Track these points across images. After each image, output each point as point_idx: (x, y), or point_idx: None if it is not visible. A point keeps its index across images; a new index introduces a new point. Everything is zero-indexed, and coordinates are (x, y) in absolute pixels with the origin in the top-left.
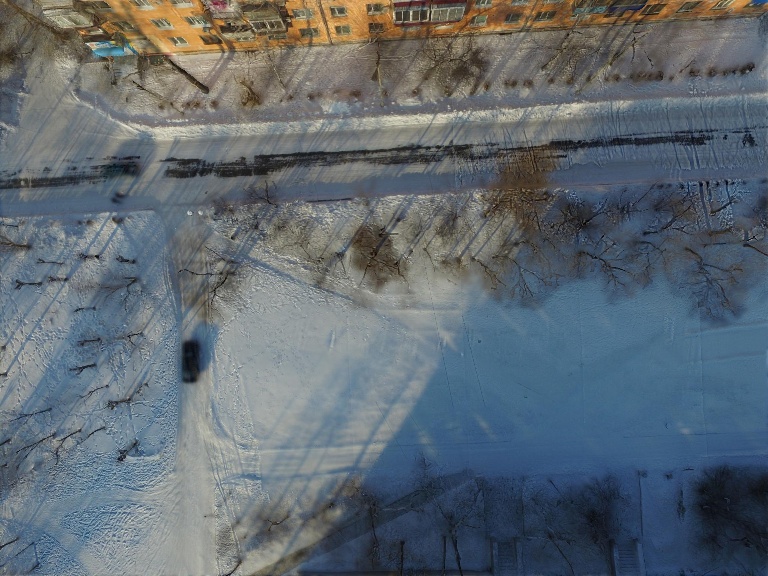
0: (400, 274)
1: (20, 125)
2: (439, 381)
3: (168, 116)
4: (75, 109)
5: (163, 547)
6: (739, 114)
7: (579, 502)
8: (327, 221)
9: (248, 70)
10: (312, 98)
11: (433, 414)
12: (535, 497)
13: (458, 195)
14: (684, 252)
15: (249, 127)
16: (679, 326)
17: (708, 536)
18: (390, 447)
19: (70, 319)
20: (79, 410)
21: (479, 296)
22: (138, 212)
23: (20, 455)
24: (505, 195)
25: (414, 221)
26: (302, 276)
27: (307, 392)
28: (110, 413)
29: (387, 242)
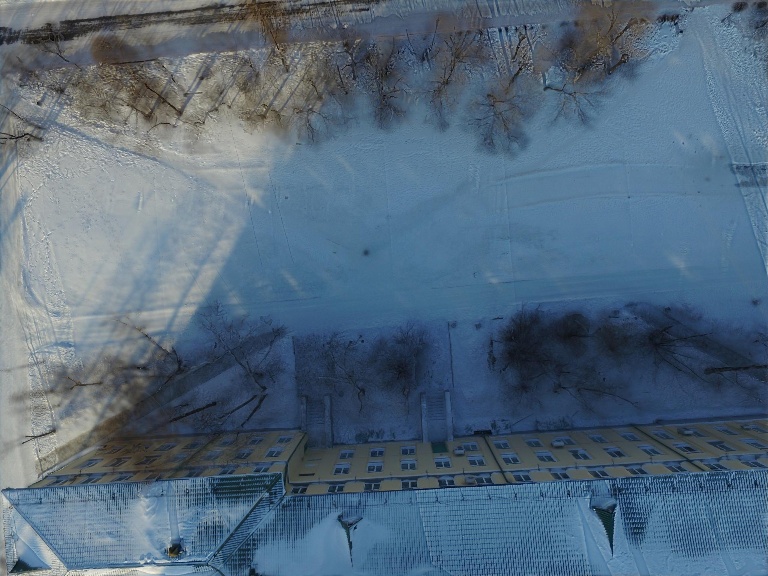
0: (195, 125)
1: None
2: (247, 239)
3: None
4: None
5: None
6: None
7: (384, 352)
8: (132, 83)
9: None
10: None
11: (242, 273)
12: None
13: (260, 51)
14: None
15: None
16: (484, 174)
17: (517, 383)
18: (201, 309)
19: None
20: None
21: (285, 152)
22: None
23: None
24: (306, 49)
25: (217, 79)
26: (109, 140)
27: (117, 256)
28: None
29: (192, 101)
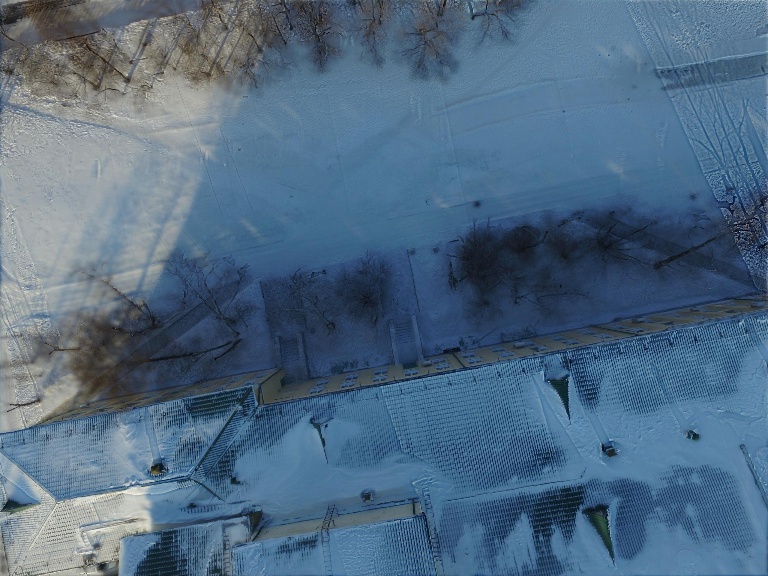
0: None
1: None
2: (206, 193)
3: None
4: None
5: None
6: None
7: None
8: (78, 56)
9: None
10: None
11: (204, 226)
12: (293, 275)
13: (198, 12)
14: None
15: None
16: (425, 105)
17: (479, 300)
18: (169, 265)
19: None
20: None
21: (233, 106)
22: None
23: None
24: (242, 5)
25: (160, 43)
26: (62, 113)
27: (81, 224)
28: None
29: (138, 68)
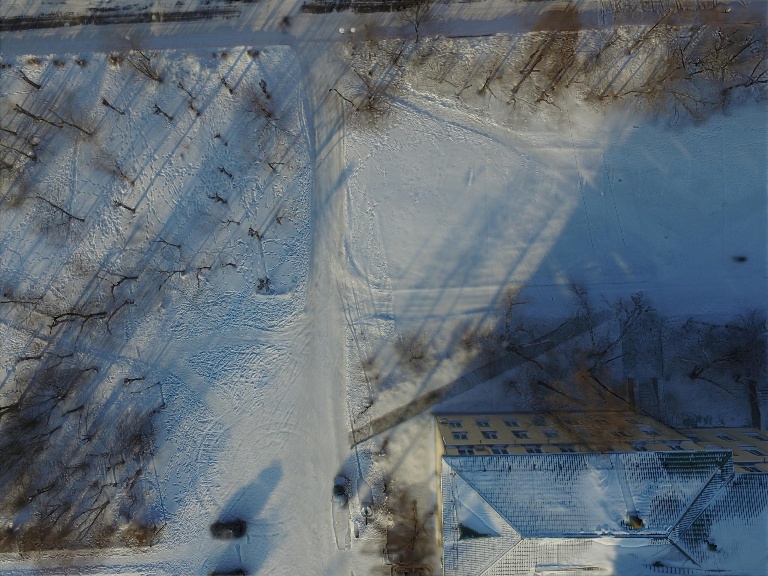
0: (549, 102)
1: None
2: (579, 220)
3: None
4: None
5: (292, 388)
6: None
7: (723, 338)
8: (467, 57)
9: None
10: None
11: (572, 253)
12: (686, 324)
13: (602, 31)
14: None
15: None
16: None
17: None
18: (527, 287)
19: (201, 155)
20: (209, 247)
21: (621, 135)
22: (273, 47)
23: (148, 293)
24: (650, 32)
25: (556, 58)
26: (440, 113)
27: (443, 231)
28: (241, 251)
29: (528, 79)
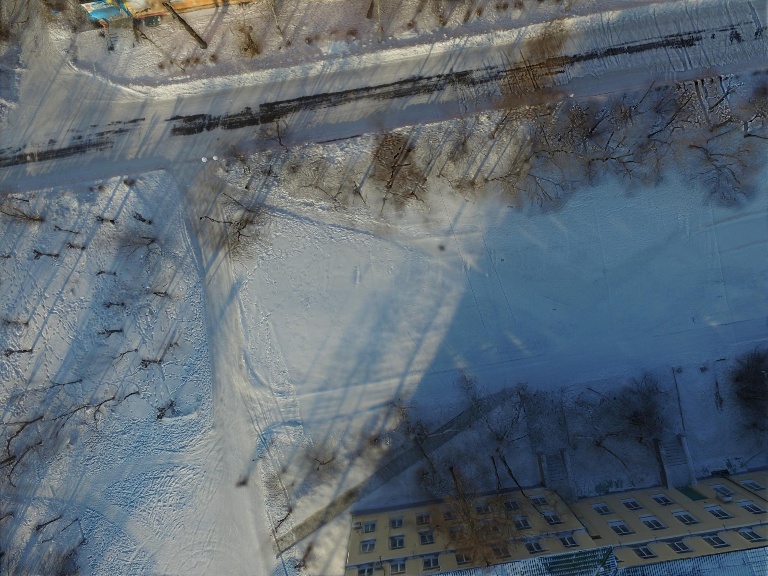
0: (418, 199)
1: (20, 101)
2: (468, 304)
3: (169, 75)
4: (74, 79)
5: (210, 506)
6: (723, 13)
7: (620, 403)
8: (339, 160)
9: (244, 22)
10: (310, 41)
11: (466, 337)
12: (578, 399)
13: (464, 119)
14: (688, 150)
15: (251, 77)
16: (693, 222)
17: (748, 422)
18: (427, 376)
19: (91, 288)
20: (110, 378)
21: (497, 216)
22: (149, 173)
23: (54, 431)
24: (510, 114)
25: (424, 150)
26: (320, 217)
27: (338, 331)
28: (142, 377)
29: (400, 173)
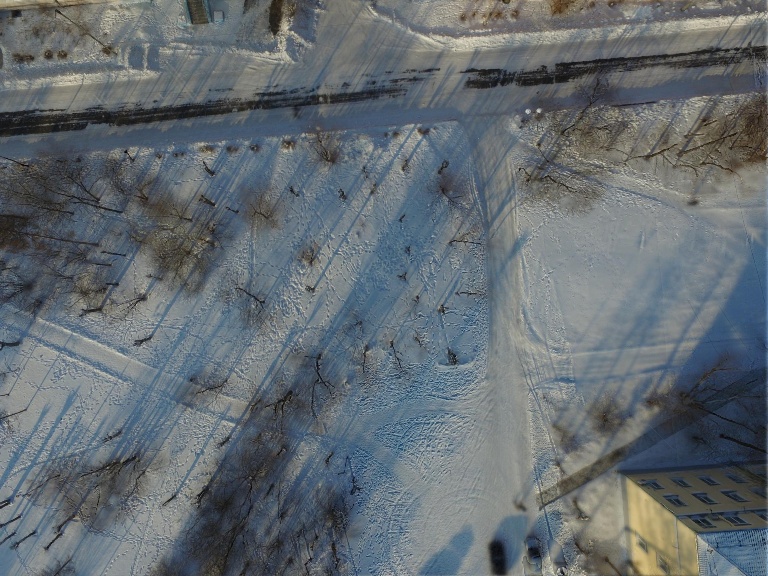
0: (724, 168)
1: (317, 41)
2: (749, 276)
3: (470, 27)
4: (372, 24)
5: (478, 455)
6: None
7: None
8: (632, 125)
9: None
10: (614, 4)
11: (745, 309)
12: None
13: (762, 94)
14: None
15: (551, 35)
16: None
17: None
18: (702, 344)
19: (377, 232)
20: (390, 322)
21: None
22: (442, 123)
23: (332, 370)
24: None
25: (719, 121)
26: (609, 180)
27: (619, 293)
28: (422, 323)
29: (693, 143)
